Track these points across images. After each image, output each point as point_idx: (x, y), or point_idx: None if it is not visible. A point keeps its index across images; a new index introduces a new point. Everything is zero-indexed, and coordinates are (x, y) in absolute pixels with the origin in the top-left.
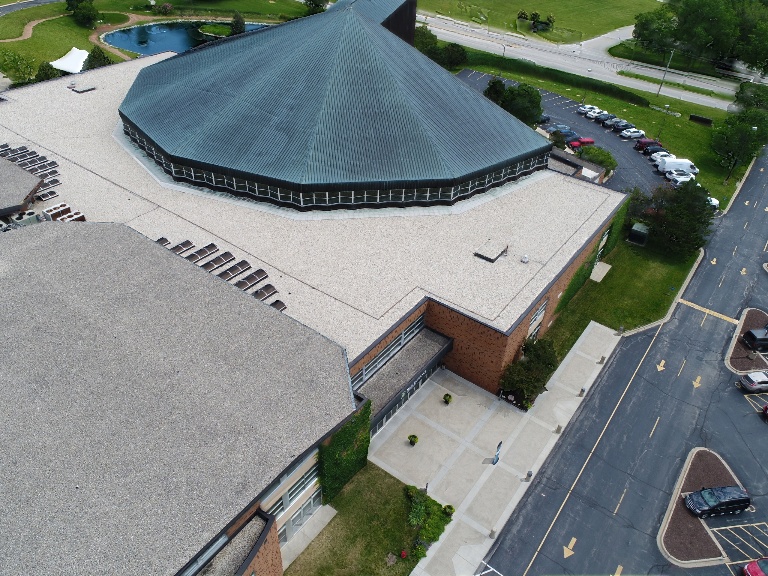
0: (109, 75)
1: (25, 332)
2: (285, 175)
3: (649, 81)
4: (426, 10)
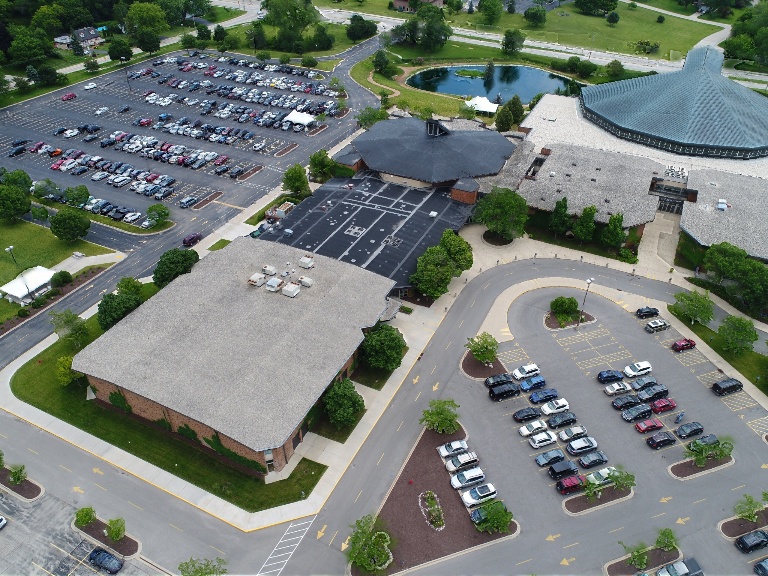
0: (547, 110)
1: (760, 197)
2: (743, 145)
3: (753, 82)
4: (600, 48)
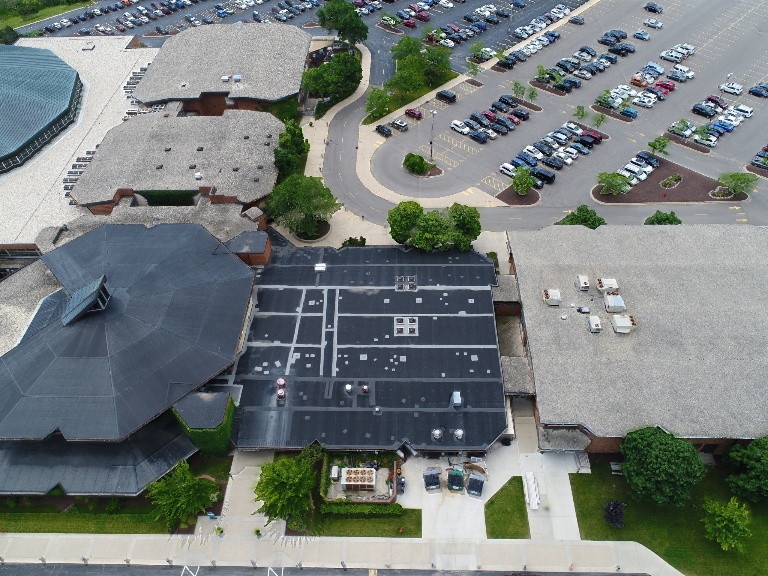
0: None
1: None
2: (73, 75)
3: None
4: None
